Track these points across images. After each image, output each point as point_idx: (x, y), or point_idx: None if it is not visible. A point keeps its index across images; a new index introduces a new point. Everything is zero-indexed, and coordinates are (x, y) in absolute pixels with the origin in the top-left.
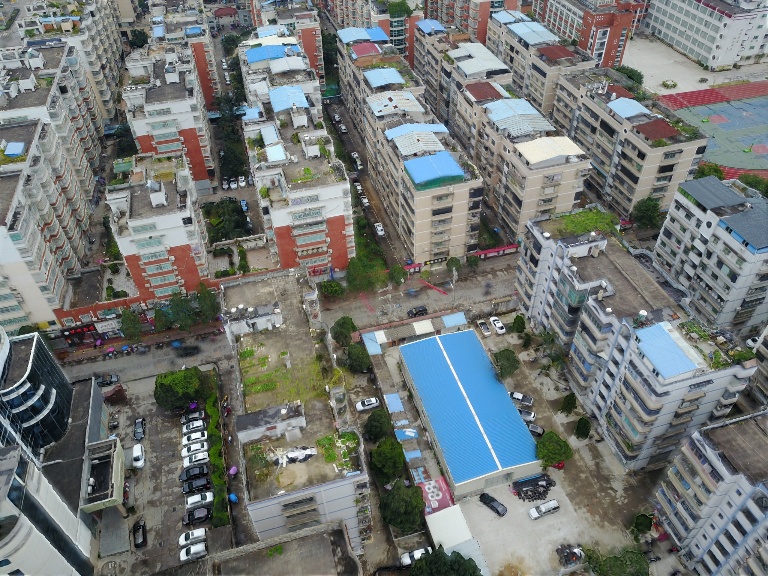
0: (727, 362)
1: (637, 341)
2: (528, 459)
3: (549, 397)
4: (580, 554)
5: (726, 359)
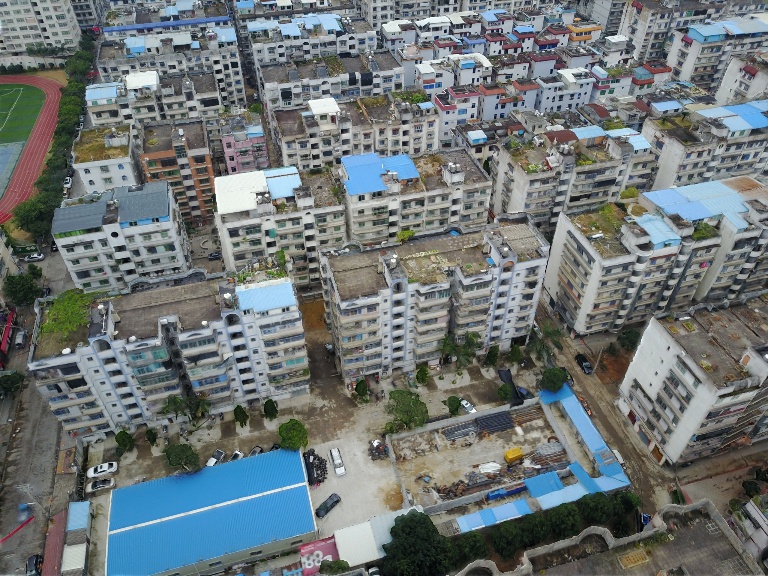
0: (278, 270)
1: (247, 313)
2: (297, 459)
3: (217, 437)
4: (378, 443)
5: (275, 270)
